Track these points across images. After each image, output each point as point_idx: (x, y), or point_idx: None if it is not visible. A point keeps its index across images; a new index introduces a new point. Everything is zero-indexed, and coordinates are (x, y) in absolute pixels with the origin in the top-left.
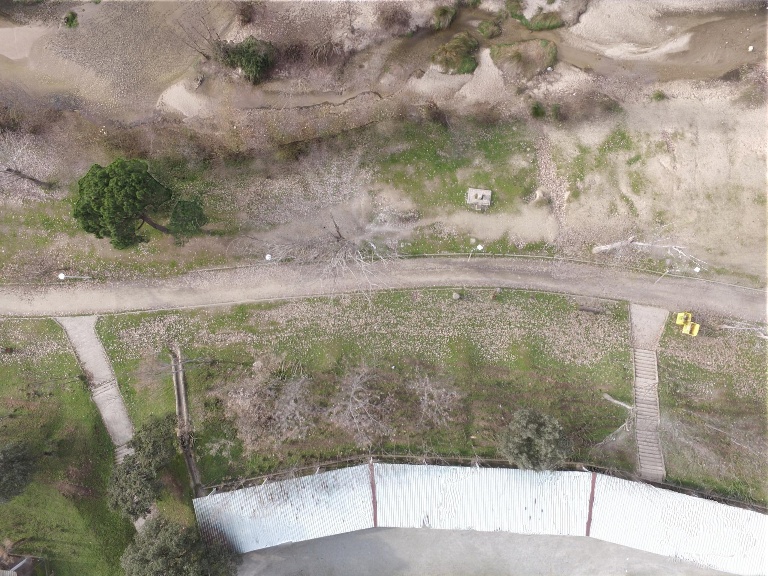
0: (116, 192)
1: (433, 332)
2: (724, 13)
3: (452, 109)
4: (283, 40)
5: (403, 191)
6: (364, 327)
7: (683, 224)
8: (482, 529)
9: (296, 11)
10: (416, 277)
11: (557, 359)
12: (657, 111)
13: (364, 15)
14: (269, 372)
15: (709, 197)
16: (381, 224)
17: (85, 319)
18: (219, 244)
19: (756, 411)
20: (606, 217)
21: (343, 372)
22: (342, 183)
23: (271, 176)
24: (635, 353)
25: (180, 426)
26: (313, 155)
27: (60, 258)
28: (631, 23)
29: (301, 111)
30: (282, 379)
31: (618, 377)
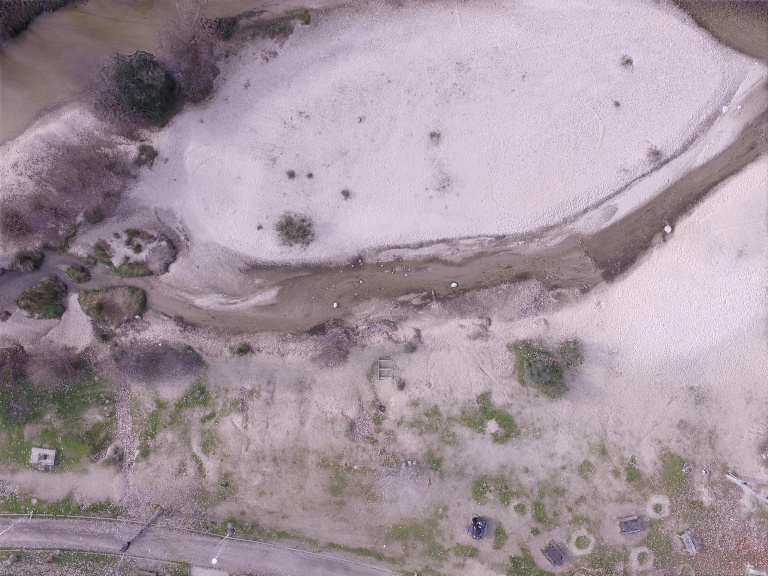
0: None
1: None
2: (311, 269)
3: (39, 353)
4: None
5: None
6: None
7: (248, 487)
8: None
9: None
10: None
11: None
12: (238, 366)
13: None
14: None
15: (275, 460)
16: None
17: None
18: None
19: None
20: (173, 477)
21: None
22: None
23: None
24: None
25: None
26: None
27: None
28: (220, 275)
29: None
30: None
31: None
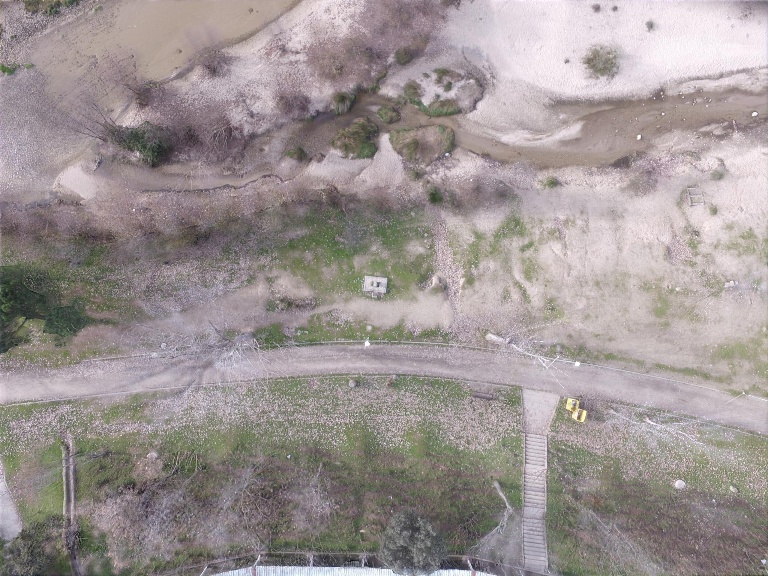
0: None
1: (330, 420)
2: (614, 102)
3: (353, 193)
4: (182, 124)
5: (300, 278)
6: (261, 415)
7: (573, 310)
8: None
9: (195, 94)
10: (313, 365)
11: (451, 445)
12: (550, 198)
13: (264, 100)
14: (163, 464)
15: (598, 284)
16: (278, 312)
17: None
18: (113, 333)
19: (641, 494)
20: (500, 303)
21: (238, 463)
22: (240, 269)
23: (169, 262)
24: (526, 438)
25: (66, 526)
26: (212, 240)
27: None
28: (526, 111)
29: (201, 194)
30: (175, 472)
31: (509, 464)
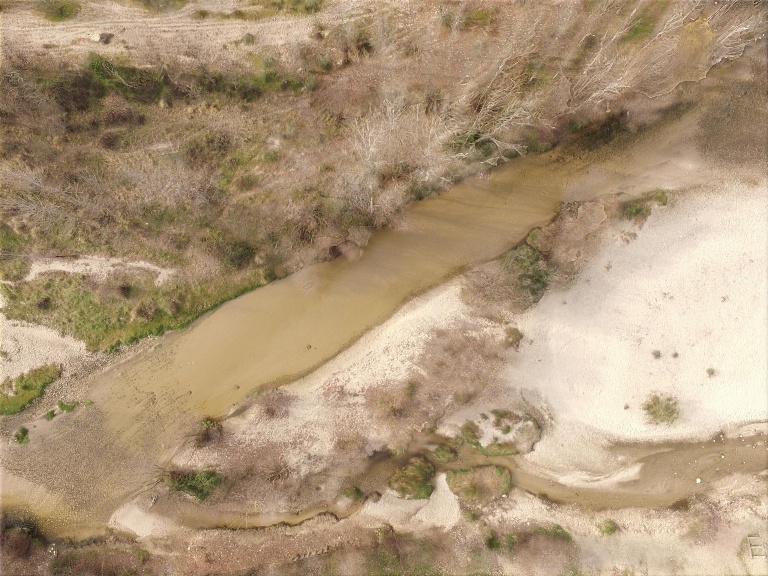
0: None
1: None
2: (673, 444)
3: (408, 532)
4: (239, 466)
5: None
6: None
7: None
8: None
9: (253, 434)
10: None
11: None
12: (608, 546)
13: (321, 441)
14: None
15: None
16: None
17: None
18: None
19: None
20: None
21: None
22: None
23: None
24: None
25: None
26: None
27: None
28: (584, 452)
29: (257, 533)
30: None
31: None
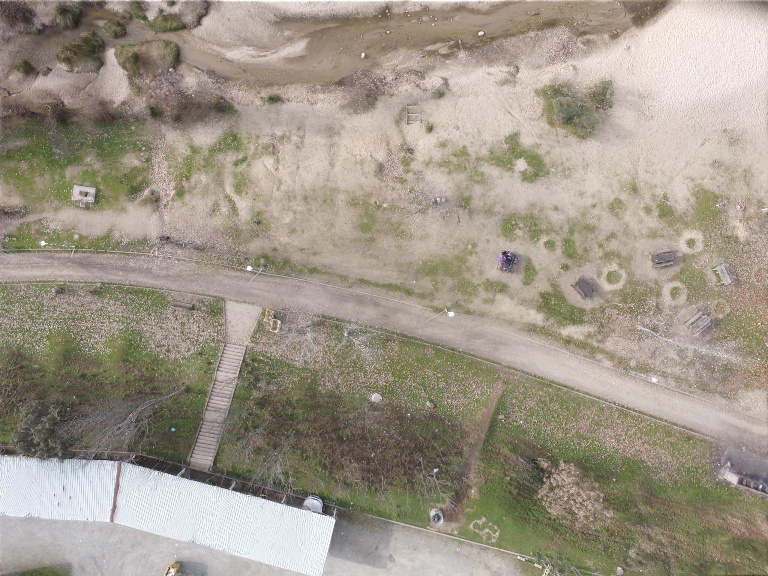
0: None
1: (35, 325)
2: (339, 20)
3: (79, 107)
4: None
5: (13, 187)
6: None
7: (280, 224)
8: (16, 514)
9: None
10: (21, 271)
11: (152, 353)
12: (269, 114)
13: None
14: None
15: (306, 199)
16: None
17: None
18: None
19: (334, 405)
20: (208, 216)
21: None
22: None
23: None
24: (225, 348)
25: None
26: None
27: None
28: (250, 27)
29: None
30: None
31: (201, 371)
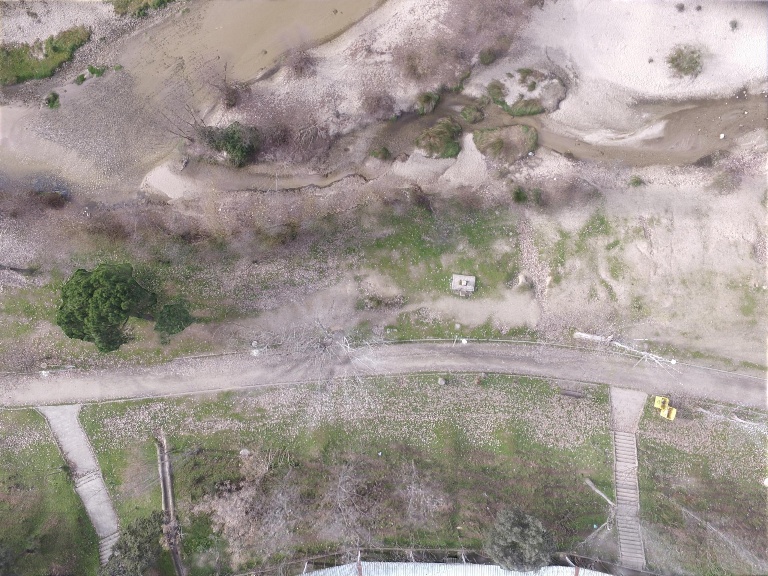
0: (101, 304)
1: (419, 417)
2: (697, 101)
3: (436, 192)
4: (268, 124)
5: (389, 277)
6: (351, 413)
7: (660, 309)
8: None
9: (281, 95)
10: (402, 362)
11: (540, 443)
12: (634, 197)
13: (349, 100)
14: (256, 461)
15: (684, 282)
16: (367, 310)
17: (68, 408)
18: (205, 331)
19: (731, 492)
20: (586, 302)
21: (330, 460)
22: (328, 268)
23: (257, 260)
24: (615, 436)
25: (166, 522)
26: (299, 239)
27: (42, 347)
28: (609, 110)
29: (287, 193)
30: (269, 469)
31: (599, 461)
